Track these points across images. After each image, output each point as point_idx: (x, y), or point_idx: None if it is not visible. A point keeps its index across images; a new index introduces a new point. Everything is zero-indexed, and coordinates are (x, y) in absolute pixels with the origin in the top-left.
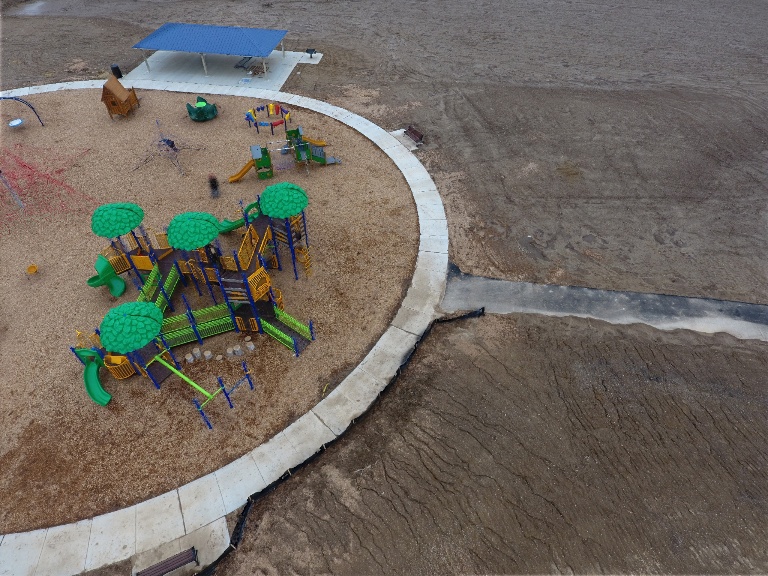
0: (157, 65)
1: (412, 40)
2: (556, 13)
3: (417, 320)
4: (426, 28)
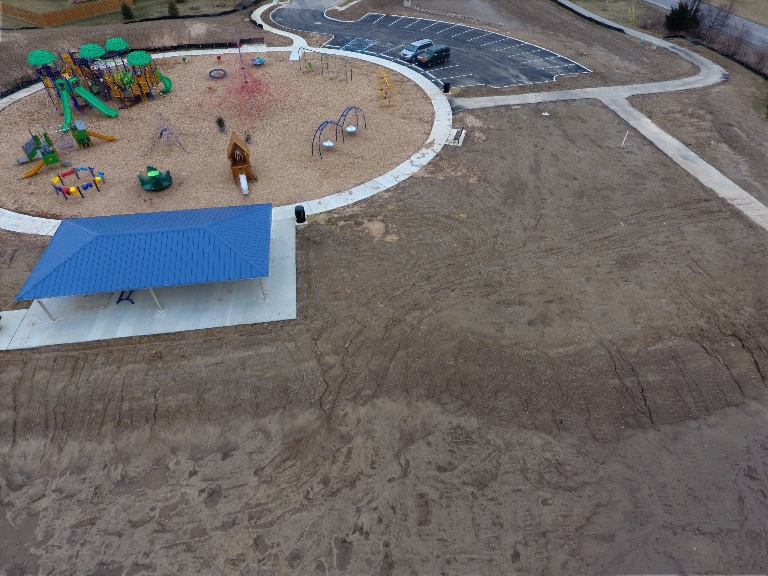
0: None
1: None
2: None
3: (3, 101)
4: None
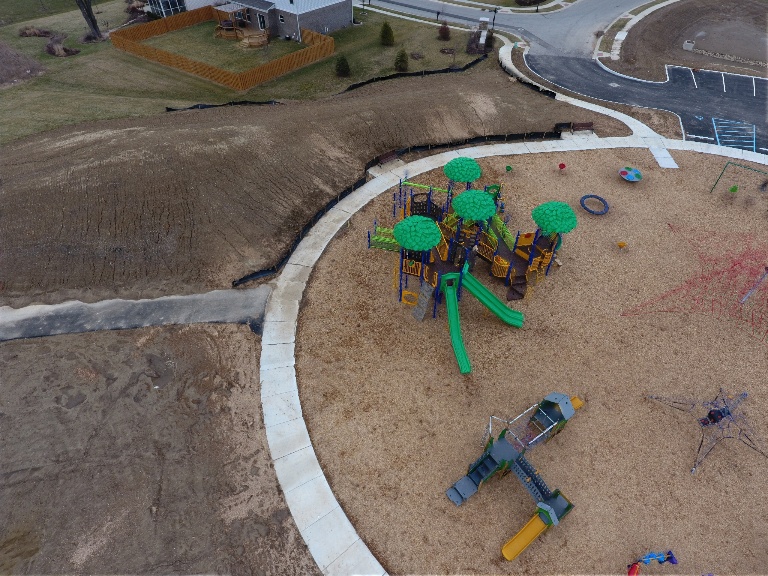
0: None
1: None
2: None
3: (291, 274)
4: None
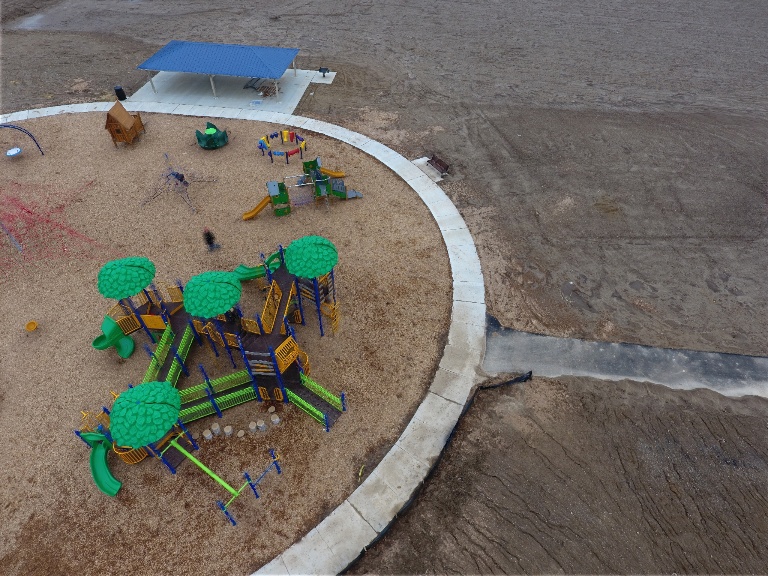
0: (163, 85)
1: (427, 56)
2: (574, 27)
3: (457, 385)
4: (441, 43)
